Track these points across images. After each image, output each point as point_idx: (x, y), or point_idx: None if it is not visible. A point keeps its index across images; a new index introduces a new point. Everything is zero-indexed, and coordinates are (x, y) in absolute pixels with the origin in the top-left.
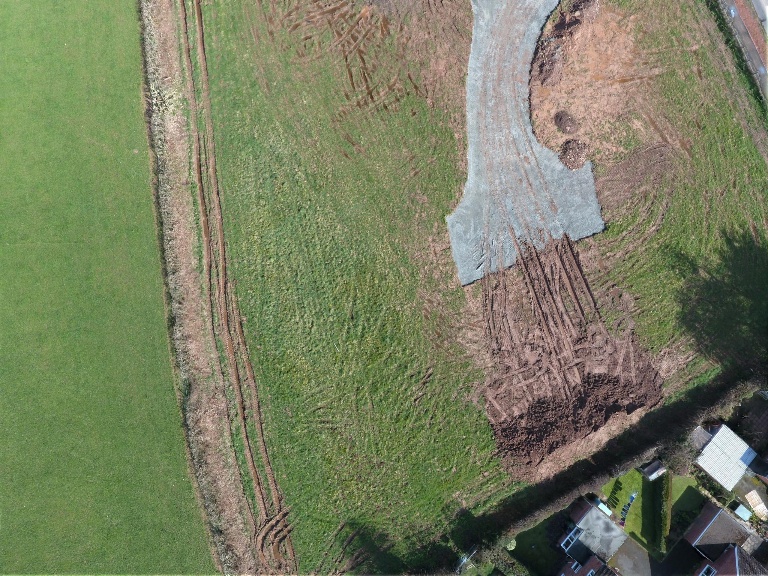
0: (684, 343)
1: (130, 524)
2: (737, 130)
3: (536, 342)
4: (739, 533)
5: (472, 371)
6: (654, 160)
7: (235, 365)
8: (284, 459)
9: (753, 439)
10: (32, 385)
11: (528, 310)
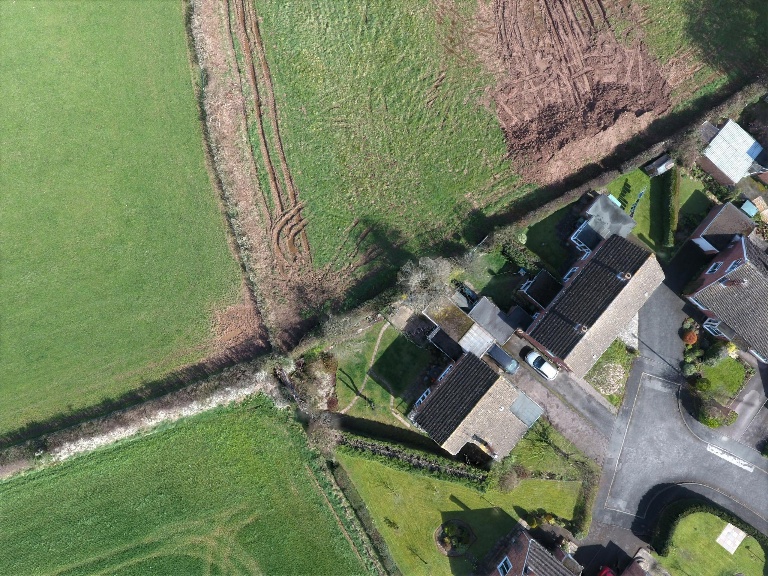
0: (691, 54)
1: (148, 213)
2: None
3: (546, 50)
4: (745, 224)
5: (484, 76)
6: None
7: (251, 64)
8: (299, 155)
9: (759, 133)
10: (52, 76)
11: (539, 18)
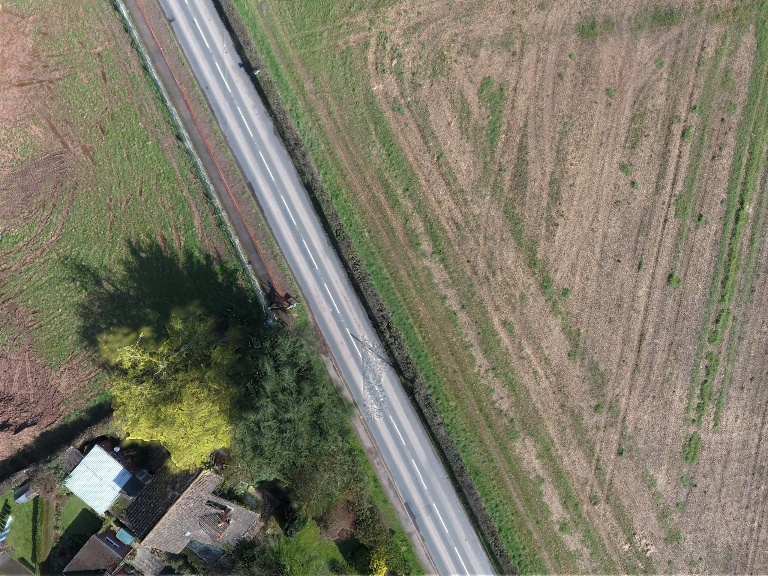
0: (86, 359)
1: None
2: (143, 135)
3: None
4: (111, 559)
5: None
6: (53, 167)
7: None
8: None
9: None
10: None
11: None
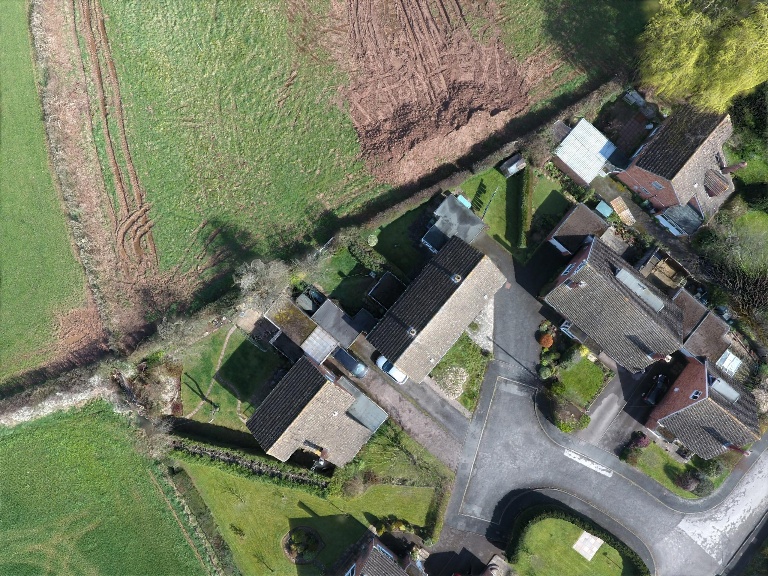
0: (550, 52)
1: None
2: None
3: (401, 48)
4: (598, 225)
5: (337, 75)
6: None
7: (97, 63)
8: (146, 156)
9: (612, 132)
10: None
11: (393, 16)
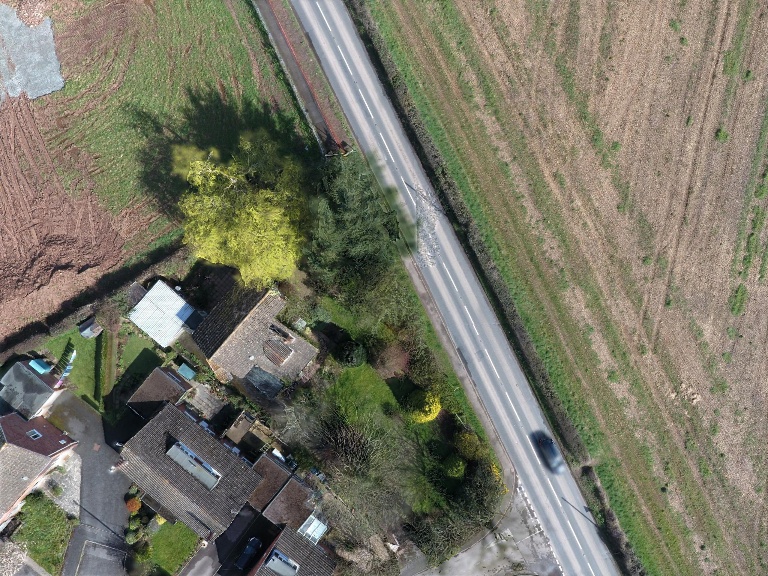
0: (146, 203)
1: None
2: None
3: None
4: (174, 390)
5: None
6: (115, 16)
7: None
8: None
9: (190, 294)
10: None
11: None
